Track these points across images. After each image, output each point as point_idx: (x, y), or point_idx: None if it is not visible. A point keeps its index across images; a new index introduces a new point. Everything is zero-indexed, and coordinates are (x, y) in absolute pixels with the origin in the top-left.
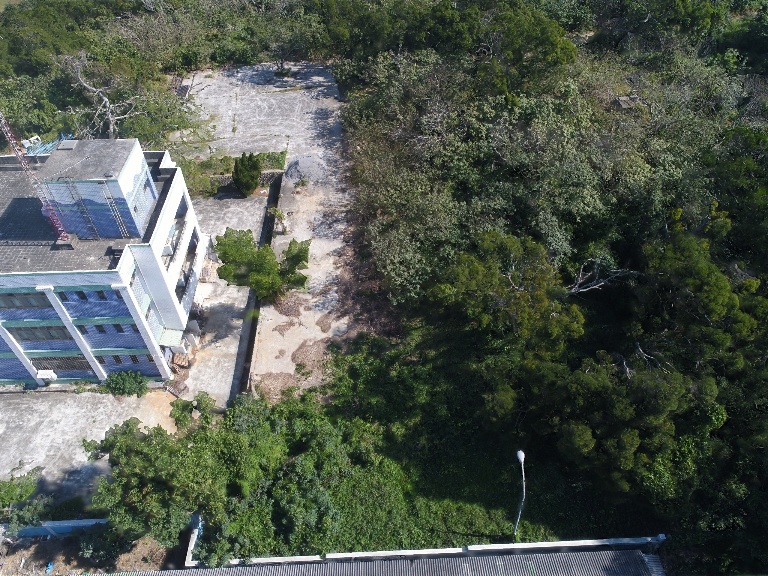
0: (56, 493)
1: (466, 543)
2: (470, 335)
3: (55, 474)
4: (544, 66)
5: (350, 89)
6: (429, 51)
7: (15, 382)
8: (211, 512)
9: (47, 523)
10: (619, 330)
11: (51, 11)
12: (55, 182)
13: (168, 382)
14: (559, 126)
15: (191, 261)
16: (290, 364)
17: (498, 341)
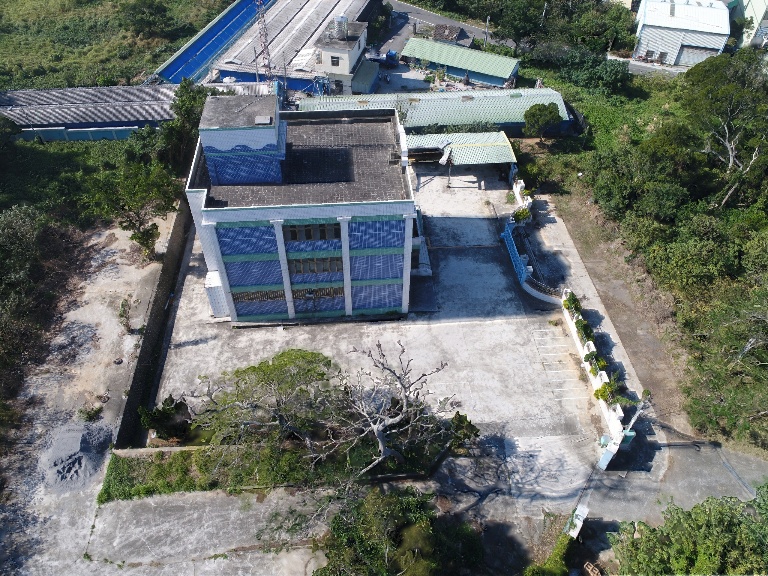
0: None
1: None
2: None
3: None
4: None
5: None
6: None
7: None
8: None
9: None
10: None
11: None
12: None
13: None
14: None
15: None
16: None
17: None
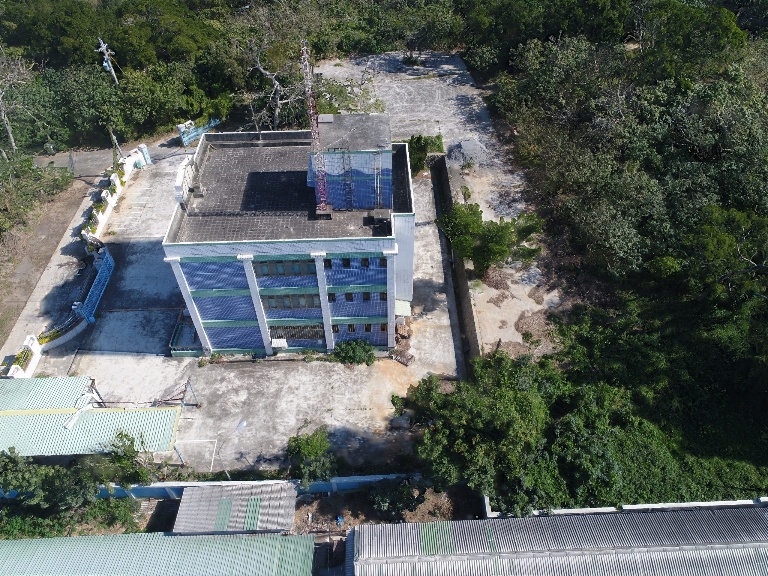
0: None
1: (745, 497)
2: (690, 306)
3: None
4: (710, 51)
5: (485, 77)
6: (581, 38)
7: (244, 351)
8: (508, 466)
9: (335, 479)
10: None
11: (173, 1)
12: (332, 152)
13: (393, 351)
14: (737, 108)
15: None
16: (516, 334)
17: (722, 311)
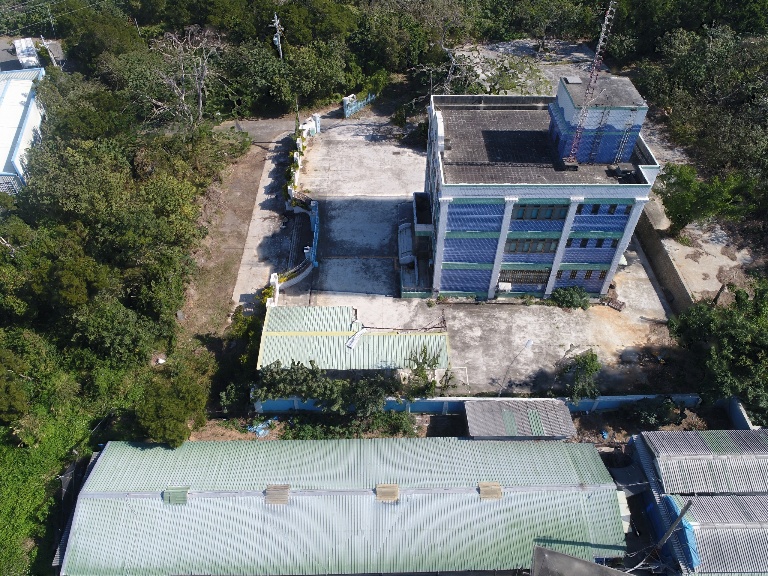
0: (562, 381)
1: None
2: None
3: (551, 367)
4: None
5: (620, 64)
6: None
7: (467, 294)
8: (767, 386)
9: (599, 397)
10: None
11: None
12: (594, 108)
13: (604, 298)
14: None
15: None
16: (720, 284)
17: None
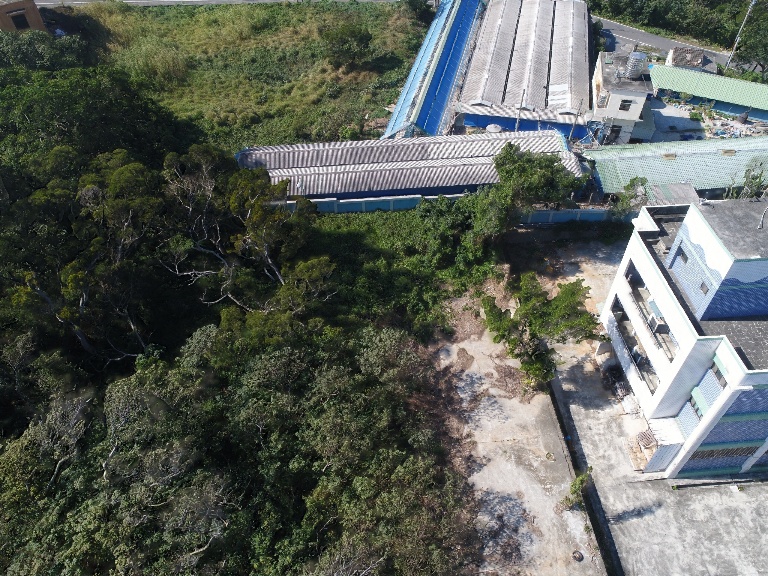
0: None
1: (337, 216)
2: None
3: None
4: None
5: None
6: None
7: None
8: None
9: None
10: (174, 302)
11: None
12: None
13: None
14: None
15: (650, 388)
16: None
17: None
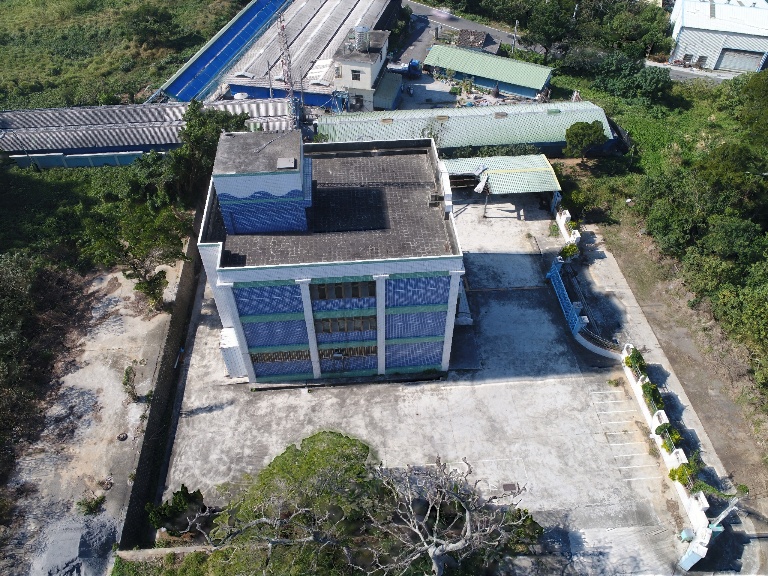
0: None
1: None
2: None
3: None
4: None
5: None
6: None
7: None
8: None
9: None
10: None
11: None
12: None
13: None
14: None
15: None
16: None
17: None
